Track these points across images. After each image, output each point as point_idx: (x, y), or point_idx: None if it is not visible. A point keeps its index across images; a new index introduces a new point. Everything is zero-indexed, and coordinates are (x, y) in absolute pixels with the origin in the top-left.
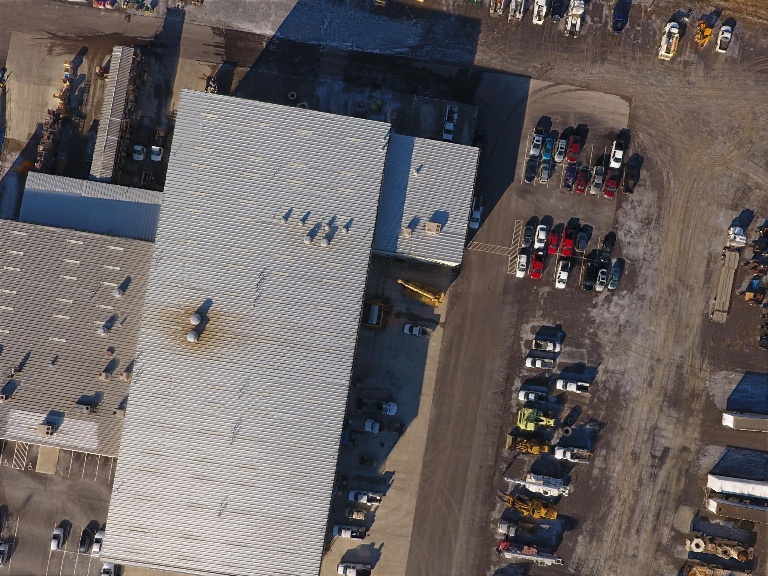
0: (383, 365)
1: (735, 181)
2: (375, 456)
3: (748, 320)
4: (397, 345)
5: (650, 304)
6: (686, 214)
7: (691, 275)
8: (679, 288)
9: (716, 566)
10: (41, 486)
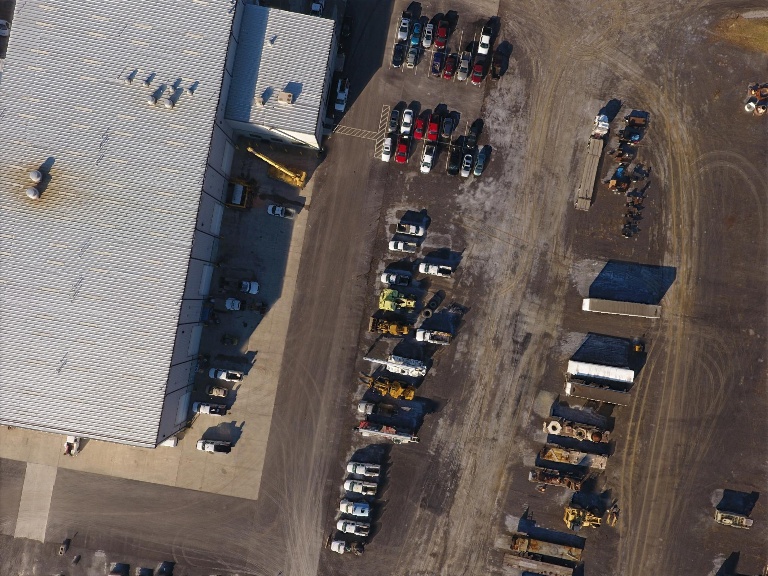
0: (247, 246)
1: (603, 71)
2: (237, 336)
3: (612, 209)
4: (262, 226)
5: (516, 191)
6: (554, 103)
7: (557, 163)
8: (545, 176)
9: (574, 450)
10: None
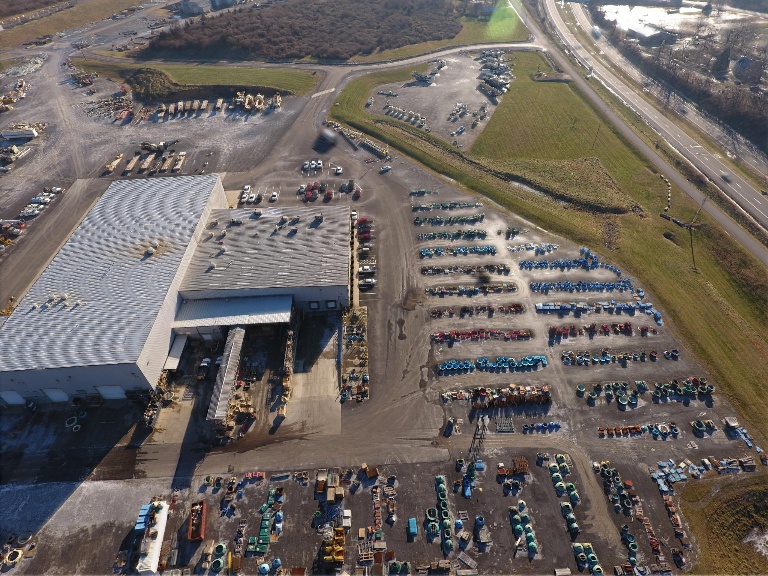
0: None
1: None
2: None
3: None
4: None
5: None
6: None
7: None
8: None
9: None
10: None
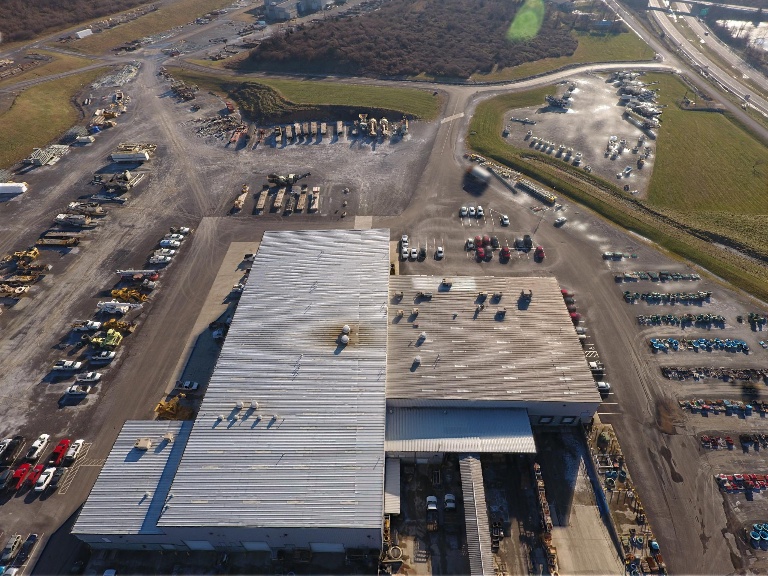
0: None
1: None
2: None
3: None
4: (207, 376)
5: None
6: None
7: None
8: None
9: (14, 284)
10: (460, 273)
